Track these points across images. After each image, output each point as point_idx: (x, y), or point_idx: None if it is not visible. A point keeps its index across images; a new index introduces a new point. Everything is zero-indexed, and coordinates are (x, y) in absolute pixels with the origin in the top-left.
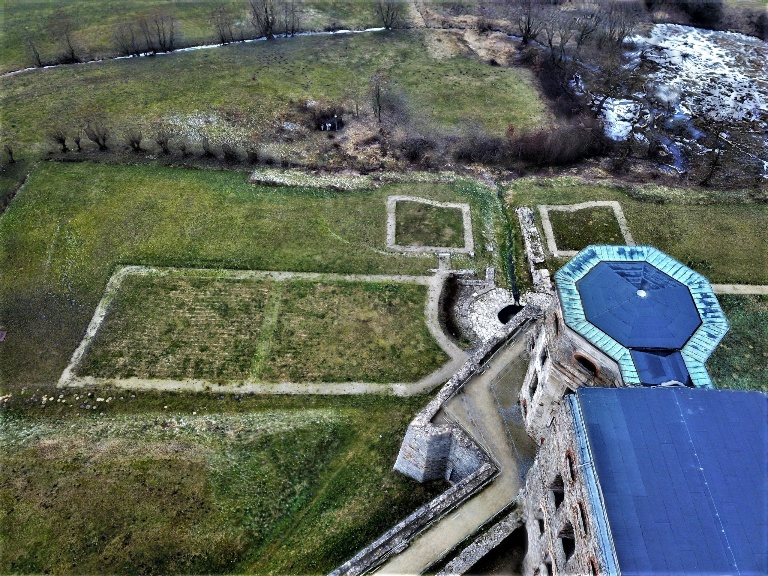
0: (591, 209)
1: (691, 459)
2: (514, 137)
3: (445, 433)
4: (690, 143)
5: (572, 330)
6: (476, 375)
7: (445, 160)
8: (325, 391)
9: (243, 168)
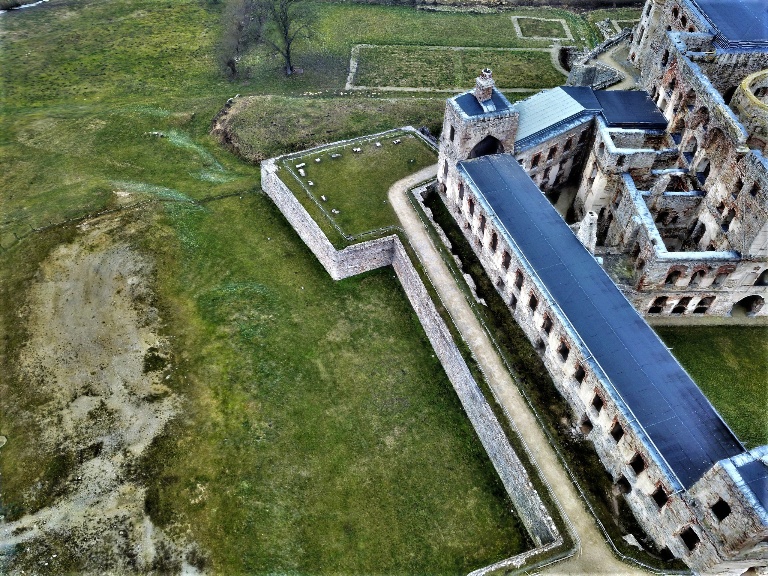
0: None
1: None
2: None
3: (593, 67)
4: None
5: None
6: (602, 52)
7: (541, 3)
8: (503, 91)
9: (408, 5)
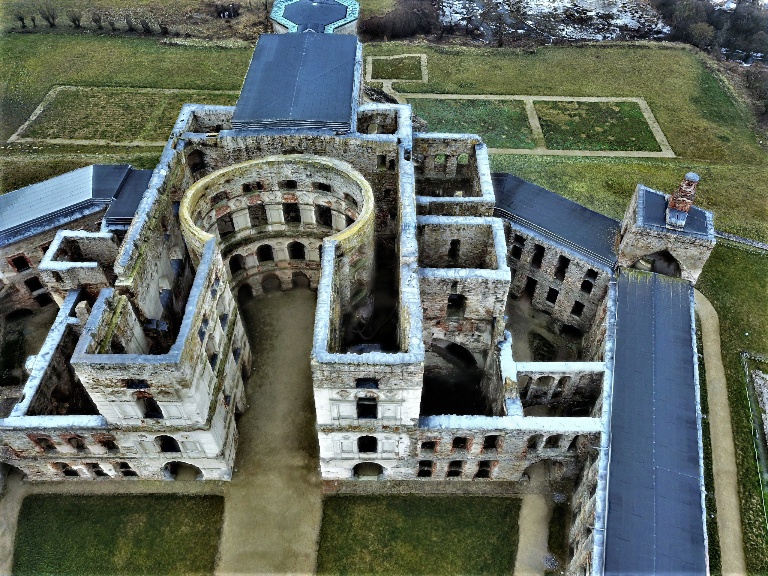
0: (404, 58)
1: (301, 51)
2: (362, 17)
3: None
4: (501, 26)
5: (271, 19)
6: None
7: None
8: None
9: (156, 37)
